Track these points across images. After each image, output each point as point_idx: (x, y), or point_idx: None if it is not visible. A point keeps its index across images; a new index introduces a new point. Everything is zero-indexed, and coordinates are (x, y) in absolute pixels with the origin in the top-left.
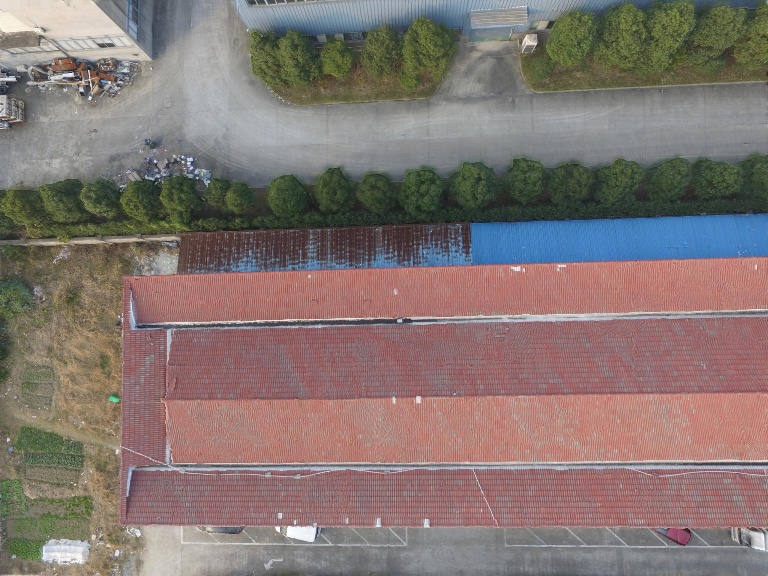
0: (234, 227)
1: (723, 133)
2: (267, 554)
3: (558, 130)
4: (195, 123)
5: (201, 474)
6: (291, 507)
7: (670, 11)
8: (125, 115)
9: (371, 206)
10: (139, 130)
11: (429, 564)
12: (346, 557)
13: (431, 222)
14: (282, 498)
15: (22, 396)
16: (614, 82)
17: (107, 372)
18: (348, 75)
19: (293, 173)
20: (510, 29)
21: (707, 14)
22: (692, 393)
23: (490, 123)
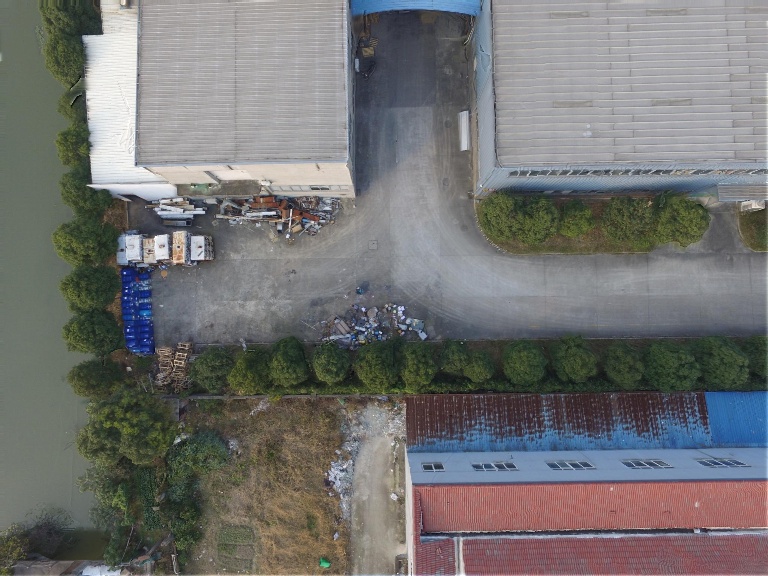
0: (462, 390)
1: None
2: None
3: None
4: (404, 268)
5: None
6: None
7: None
8: (327, 256)
9: (623, 384)
10: (343, 273)
11: None
12: None
13: None
14: None
15: (218, 559)
16: None
17: (315, 534)
18: None
19: (510, 326)
20: None
21: None
22: None
23: (709, 281)
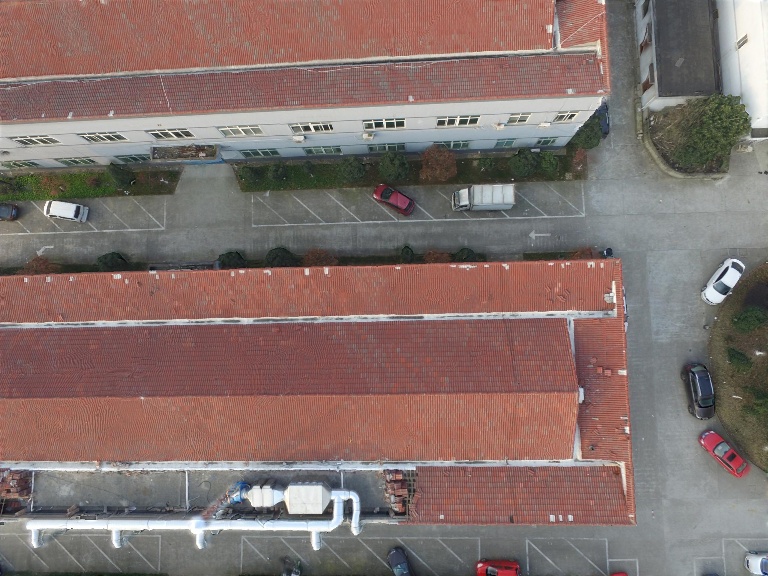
0: None
1: None
2: (40, 242)
3: None
4: None
5: None
6: None
7: None
8: None
9: None
10: None
11: (184, 245)
12: (110, 242)
13: None
14: None
15: None
16: None
17: None
18: None
19: None
20: None
21: None
22: None
23: None
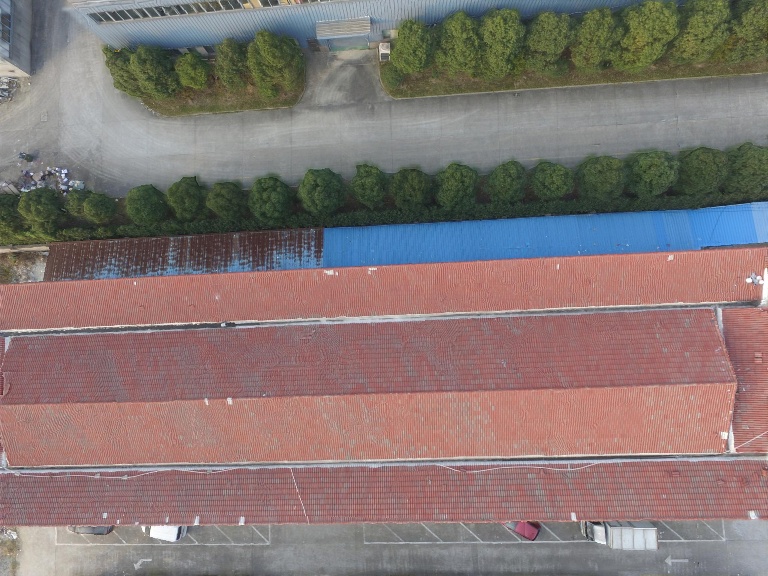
0: (99, 236)
1: (574, 135)
2: (137, 554)
3: (415, 135)
4: (70, 136)
5: (35, 476)
6: (116, 507)
7: (495, 18)
8: (4, 130)
9: (220, 214)
10: (17, 144)
11: (291, 562)
12: (212, 556)
13: (287, 228)
14: None
15: None
16: (469, 87)
17: None
18: (214, 86)
19: (162, 182)
20: (364, 38)
21: (536, 20)
22: (488, 390)
23: (350, 130)
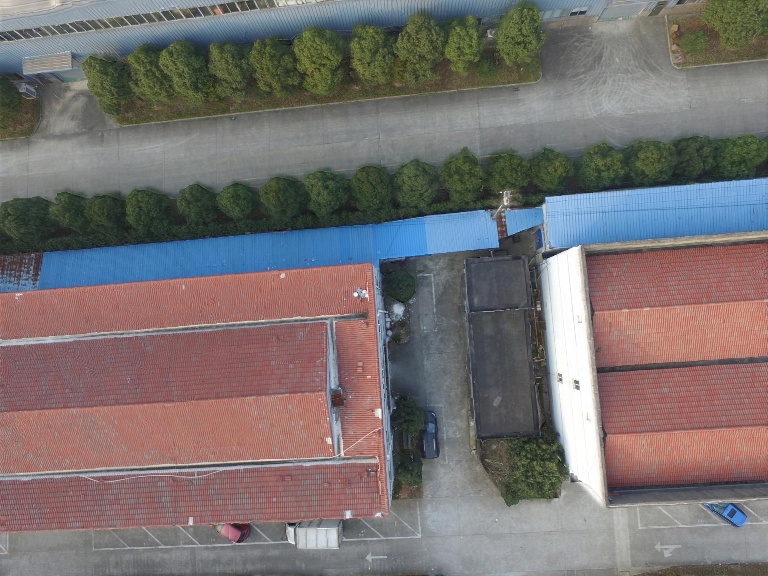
0: None
1: (285, 155)
2: None
3: (140, 160)
4: None
5: None
6: None
7: None
8: None
9: None
10: None
11: (27, 570)
12: None
13: (12, 253)
14: None
15: None
16: (189, 113)
17: None
18: None
19: None
20: None
21: None
22: (106, 406)
23: (81, 157)
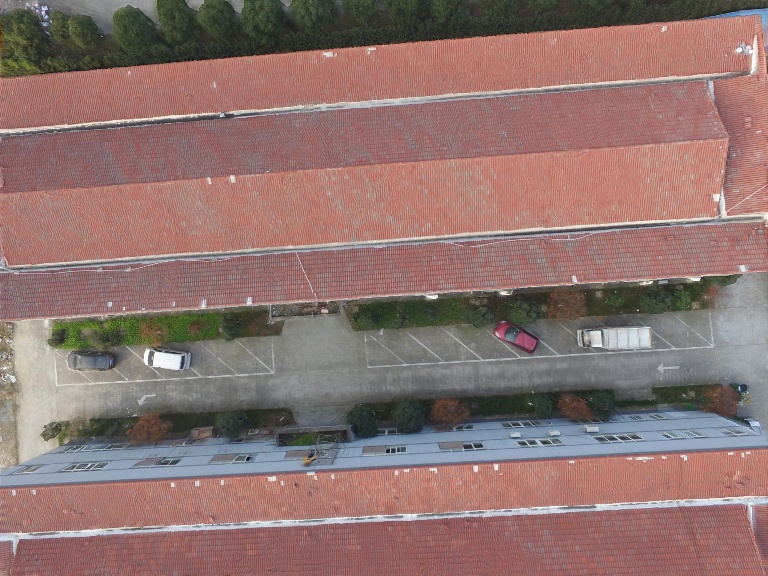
0: (86, 67)
1: None
2: (140, 390)
3: None
4: None
5: (35, 274)
6: (121, 296)
7: None
8: None
9: (211, 29)
10: None
11: (296, 389)
12: (216, 388)
13: (280, 53)
14: (113, 289)
15: None
16: None
17: None
18: None
19: None
20: None
21: None
22: (490, 156)
23: None
